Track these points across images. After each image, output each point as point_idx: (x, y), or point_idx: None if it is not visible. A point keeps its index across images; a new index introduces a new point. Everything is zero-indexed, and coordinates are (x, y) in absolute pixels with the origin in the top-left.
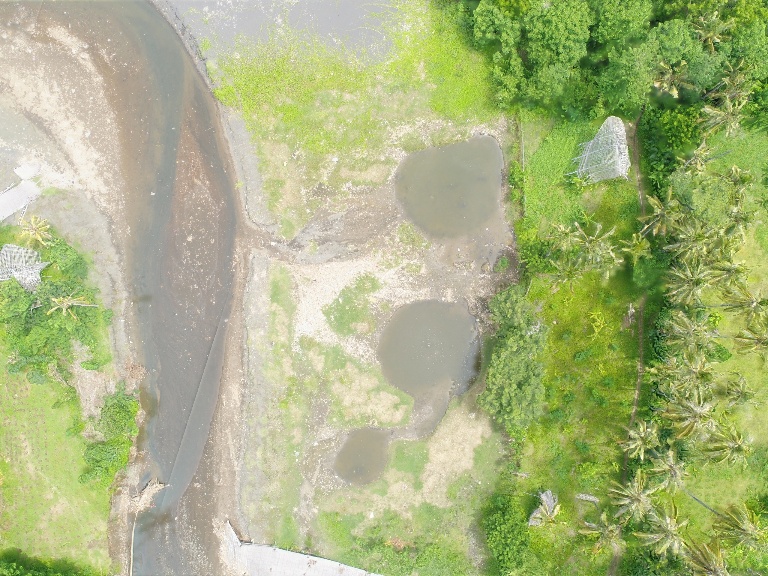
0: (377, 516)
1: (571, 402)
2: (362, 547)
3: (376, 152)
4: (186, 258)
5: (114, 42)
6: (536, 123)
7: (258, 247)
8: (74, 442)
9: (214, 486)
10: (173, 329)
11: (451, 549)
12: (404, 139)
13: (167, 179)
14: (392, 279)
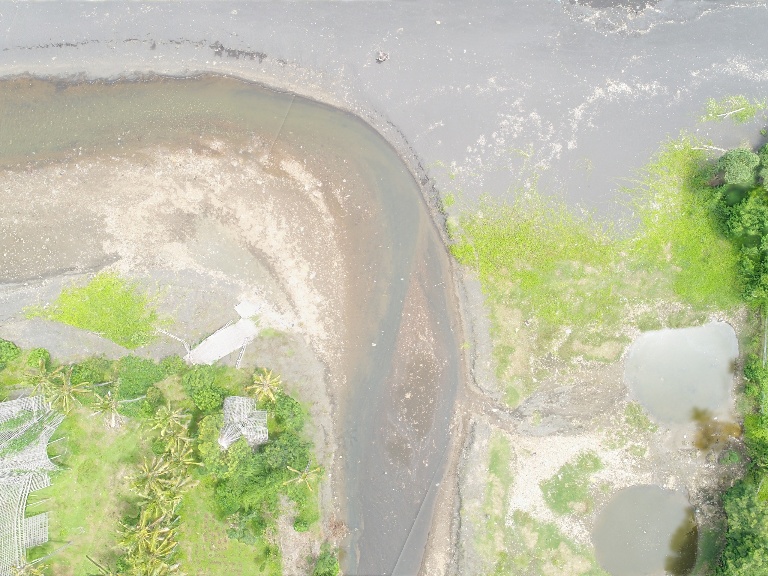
0: None
1: None
2: None
3: (611, 328)
4: (402, 415)
5: (349, 183)
6: None
7: (479, 412)
8: None
9: None
10: (381, 488)
11: None
12: (641, 318)
13: (390, 331)
14: (614, 460)
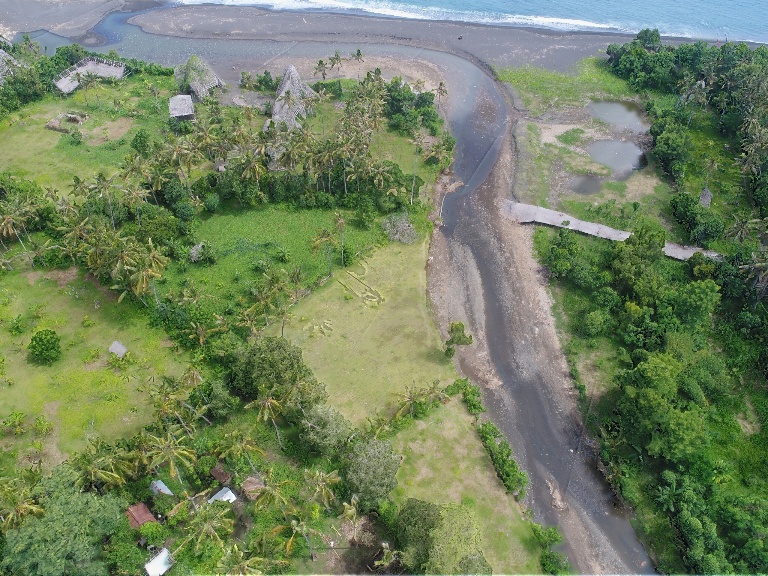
0: (599, 205)
1: (706, 170)
2: (593, 212)
3: (577, 98)
4: None
5: None
6: (655, 94)
7: None
8: (417, 157)
9: (495, 187)
10: (472, 136)
11: (651, 220)
12: None
13: None
14: None
